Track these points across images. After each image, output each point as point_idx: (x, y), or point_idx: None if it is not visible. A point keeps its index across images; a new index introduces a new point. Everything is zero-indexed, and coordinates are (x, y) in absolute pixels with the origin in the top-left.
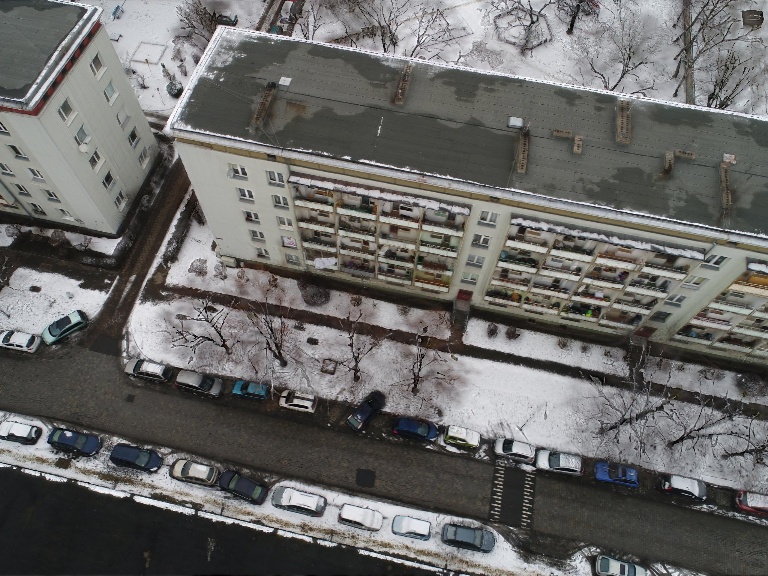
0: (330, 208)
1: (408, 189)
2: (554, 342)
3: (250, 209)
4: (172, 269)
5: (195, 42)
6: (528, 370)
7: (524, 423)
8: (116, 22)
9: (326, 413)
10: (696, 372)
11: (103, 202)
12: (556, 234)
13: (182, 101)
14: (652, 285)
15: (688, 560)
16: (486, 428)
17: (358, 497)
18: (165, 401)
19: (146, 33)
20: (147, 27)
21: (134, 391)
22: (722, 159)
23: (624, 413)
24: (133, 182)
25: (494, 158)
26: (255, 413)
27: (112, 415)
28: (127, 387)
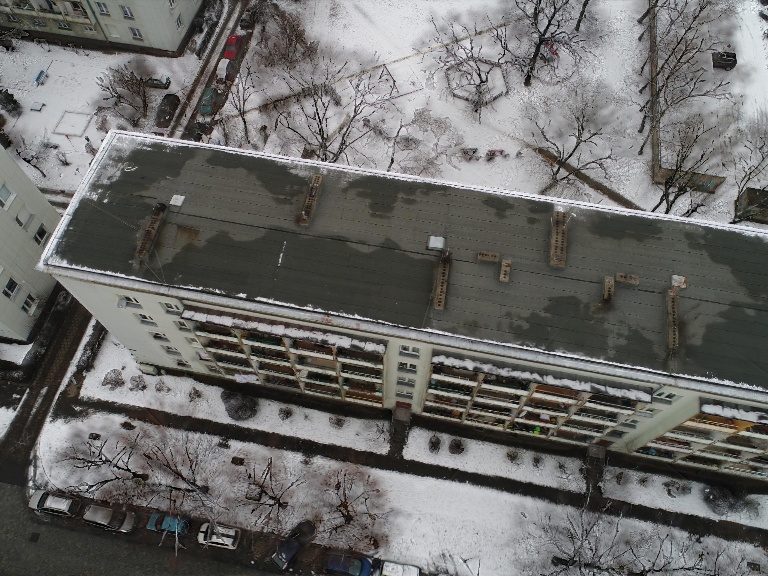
0: (234, 339)
1: (315, 325)
2: (504, 453)
3: (155, 330)
4: (87, 379)
5: (123, 109)
6: (474, 488)
7: (468, 553)
8: (40, 89)
9: (250, 548)
10: (660, 484)
11: (5, 312)
12: (483, 373)
13: (59, 230)
14: (601, 411)
15: None
16: (426, 561)
17: None
18: (73, 539)
19: (71, 100)
20: (73, 93)
21: (39, 528)
22: (670, 282)
23: (573, 555)
24: (45, 281)
25: (410, 290)
26: (171, 551)
27: (13, 559)
28: (31, 524)
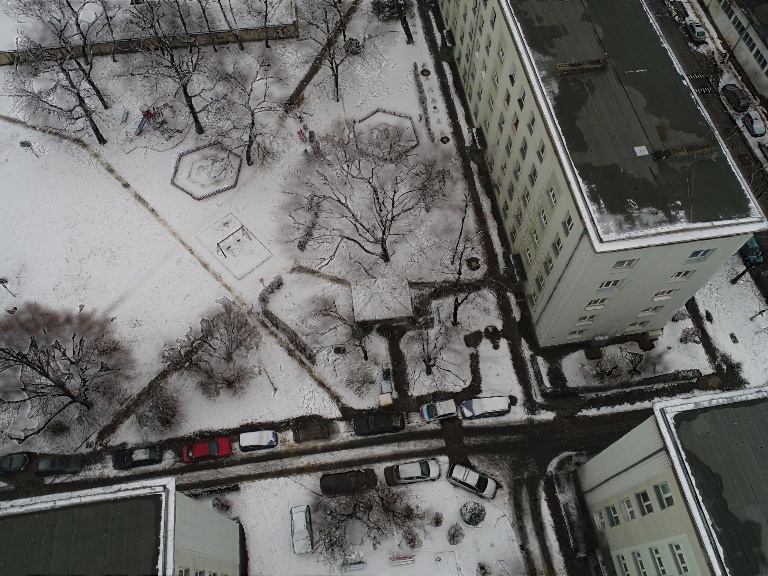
0: None
1: None
2: None
3: None
4: None
5: (365, 547)
6: None
7: None
8: None
9: None
10: None
11: None
12: None
13: (731, 223)
14: None
15: (663, 8)
16: None
17: (760, 160)
18: None
19: None
20: None
21: None
22: None
23: None
24: None
25: (613, 2)
26: None
27: None
28: None
